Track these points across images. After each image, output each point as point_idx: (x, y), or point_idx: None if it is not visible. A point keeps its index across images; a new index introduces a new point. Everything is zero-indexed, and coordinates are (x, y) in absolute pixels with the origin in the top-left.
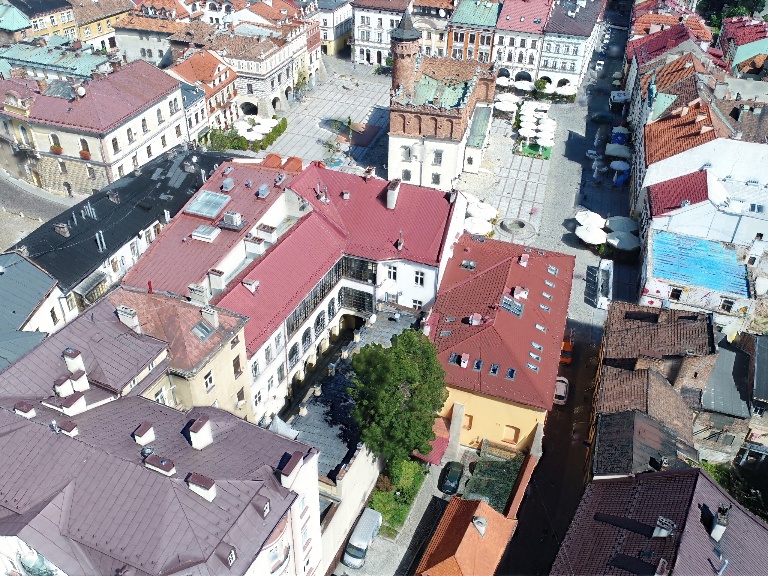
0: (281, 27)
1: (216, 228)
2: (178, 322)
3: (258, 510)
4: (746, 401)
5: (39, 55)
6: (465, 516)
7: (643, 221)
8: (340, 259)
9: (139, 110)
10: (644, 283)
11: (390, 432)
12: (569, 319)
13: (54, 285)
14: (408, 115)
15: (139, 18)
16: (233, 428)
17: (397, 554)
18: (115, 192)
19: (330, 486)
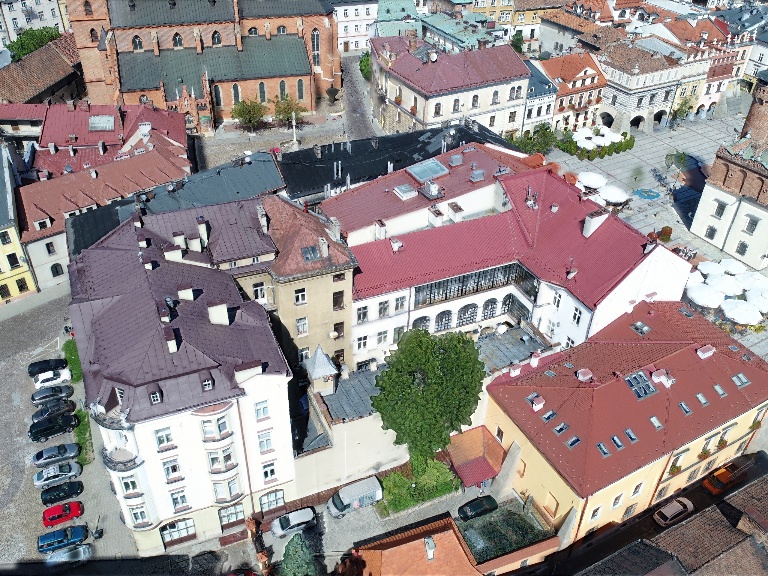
0: (688, 49)
1: (414, 190)
2: (296, 238)
3: None
4: None
5: (448, 25)
6: (430, 533)
7: None
8: (512, 264)
9: (473, 86)
10: None
11: None
12: (767, 456)
13: (281, 187)
14: (733, 166)
15: (565, 14)
16: (257, 327)
17: (373, 530)
18: (376, 138)
19: None
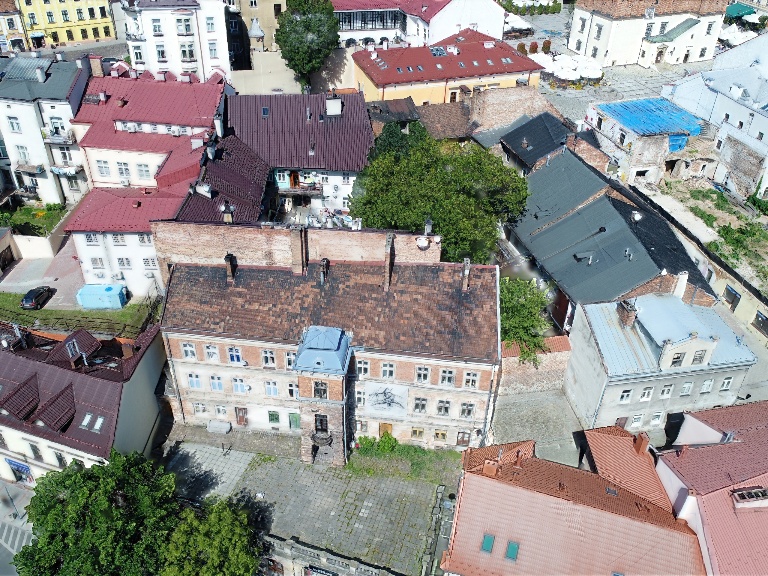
0: None
1: None
2: None
3: None
4: None
5: None
6: None
7: None
8: (396, 11)
9: None
10: None
11: None
12: None
13: None
14: None
15: None
16: None
17: None
18: None
19: None
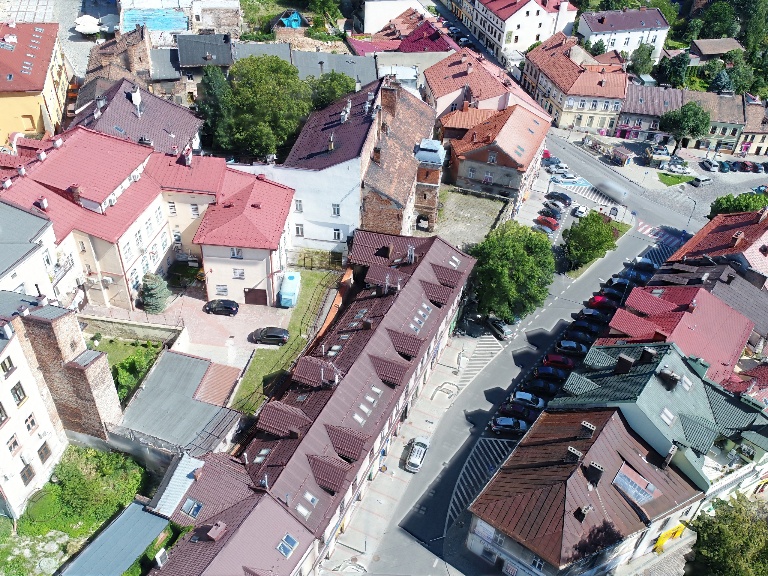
0: None
1: None
2: None
3: None
4: (179, 71)
5: None
6: None
7: None
8: None
9: None
10: None
11: None
12: None
13: None
14: None
15: None
16: None
17: None
18: None
19: None
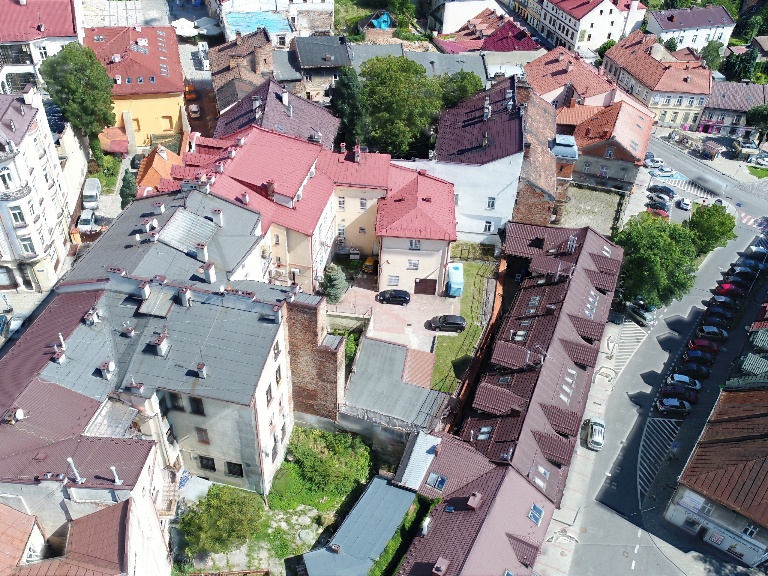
0: None
1: None
2: None
3: (17, 110)
4: (299, 72)
5: None
6: (152, 156)
7: (218, 14)
8: None
9: None
10: (228, 40)
11: (83, 104)
12: None
13: None
14: None
15: None
16: None
17: (119, 198)
18: None
19: (56, 148)
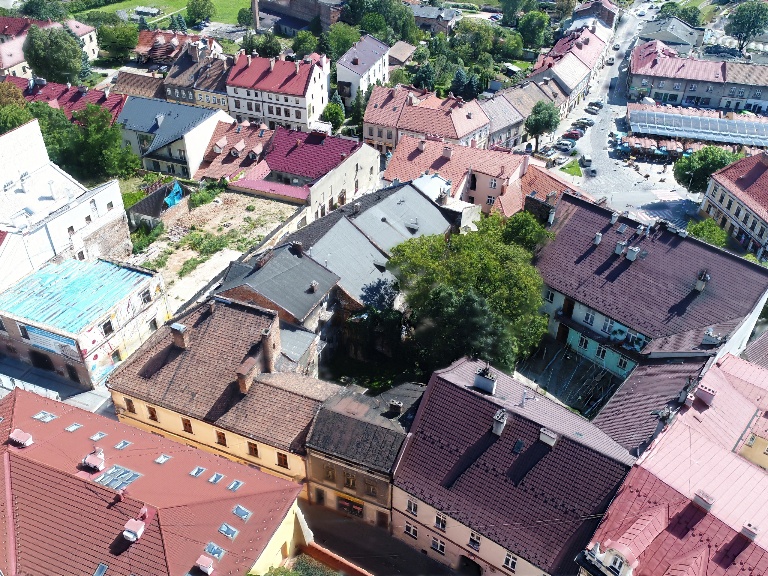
0: None
1: None
2: None
3: None
4: (298, 329)
5: None
6: None
7: None
8: None
9: None
10: (77, 348)
11: None
12: None
13: None
14: None
15: None
16: None
17: None
18: None
19: None
